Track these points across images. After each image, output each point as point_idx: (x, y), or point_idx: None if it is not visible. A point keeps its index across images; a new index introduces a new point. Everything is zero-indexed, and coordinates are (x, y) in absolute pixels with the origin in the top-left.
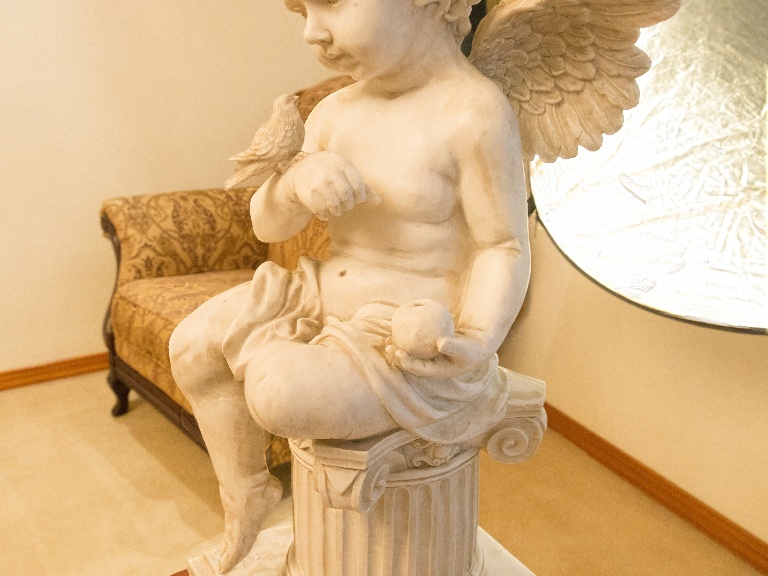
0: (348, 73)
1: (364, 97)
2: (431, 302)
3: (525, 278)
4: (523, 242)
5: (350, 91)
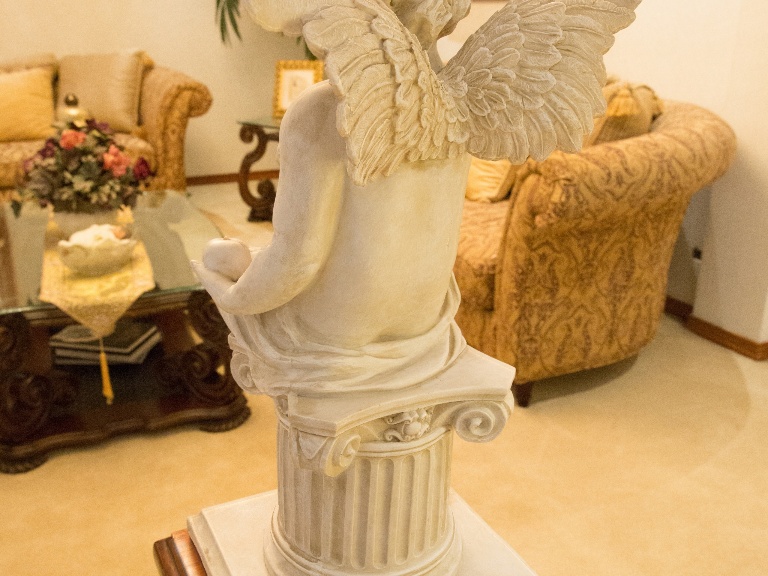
0: None
1: None
2: (224, 240)
3: (263, 267)
4: (277, 237)
5: None
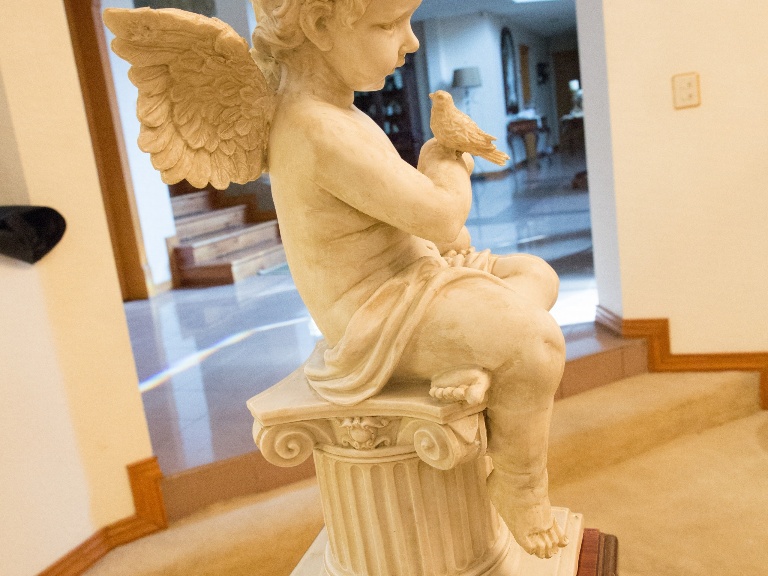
0: None
1: (351, 112)
2: None
3: None
4: None
5: (337, 110)
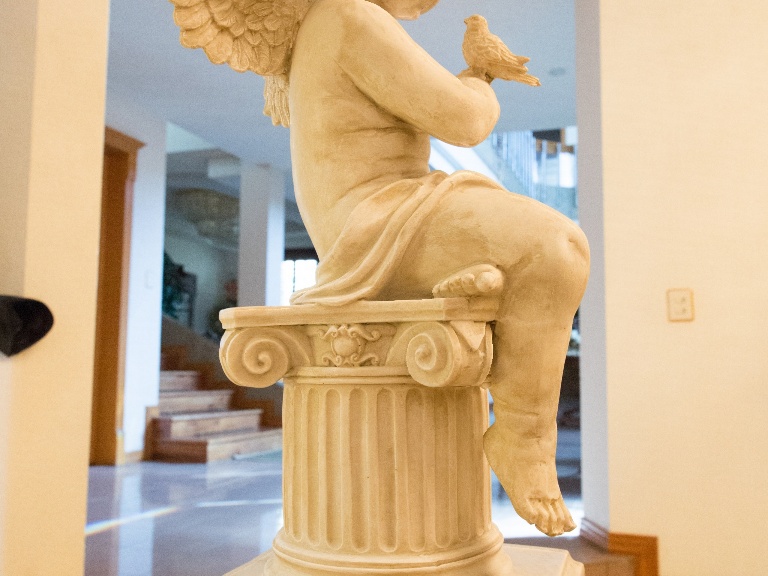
0: (413, 7)
1: None
2: None
3: None
4: None
5: None
